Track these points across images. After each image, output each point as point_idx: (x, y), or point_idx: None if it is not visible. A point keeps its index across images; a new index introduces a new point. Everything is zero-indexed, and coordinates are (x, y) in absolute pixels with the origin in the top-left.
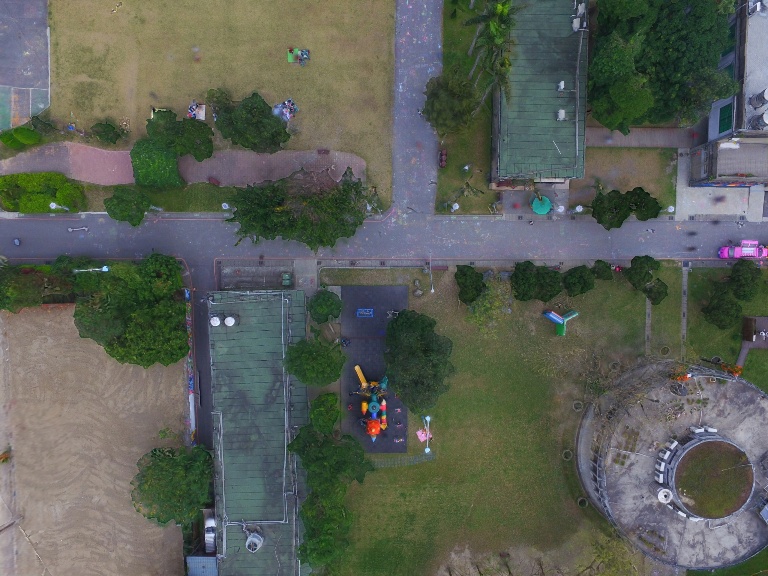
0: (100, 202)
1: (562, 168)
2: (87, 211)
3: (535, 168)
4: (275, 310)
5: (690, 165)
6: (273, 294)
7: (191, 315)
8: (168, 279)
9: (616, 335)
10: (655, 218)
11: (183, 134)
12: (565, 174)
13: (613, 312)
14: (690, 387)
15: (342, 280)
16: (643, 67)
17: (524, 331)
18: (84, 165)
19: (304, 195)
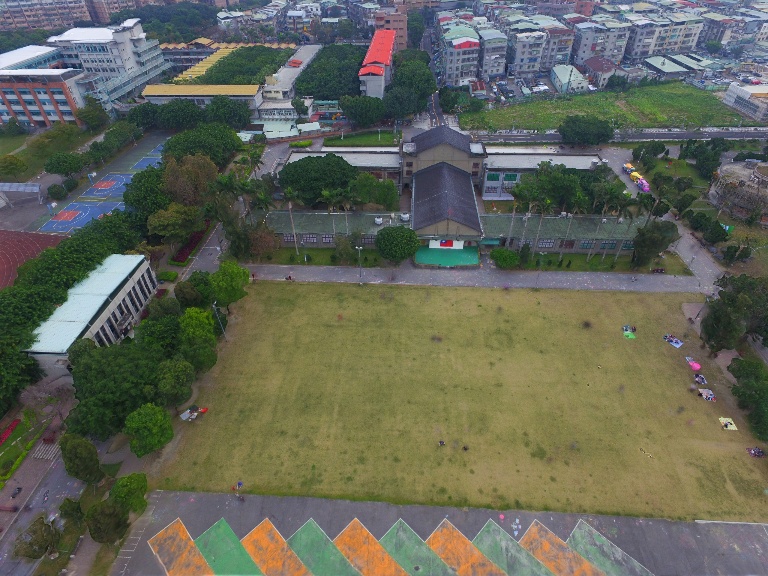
0: None
1: None
2: None
3: None
4: None
5: None
6: None
7: None
8: None
9: (713, 217)
10: None
11: None
12: None
13: None
14: (736, 183)
15: None
16: None
17: None
18: None
19: (761, 285)
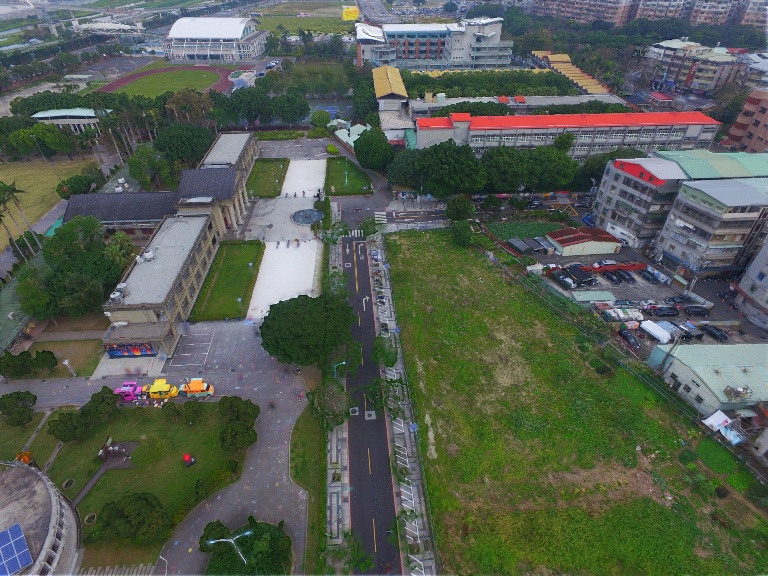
0: None
1: None
2: None
3: None
4: None
5: None
6: None
7: None
8: None
9: None
10: (74, 379)
11: None
12: None
13: None
14: None
15: None
16: None
17: None
18: None
19: None
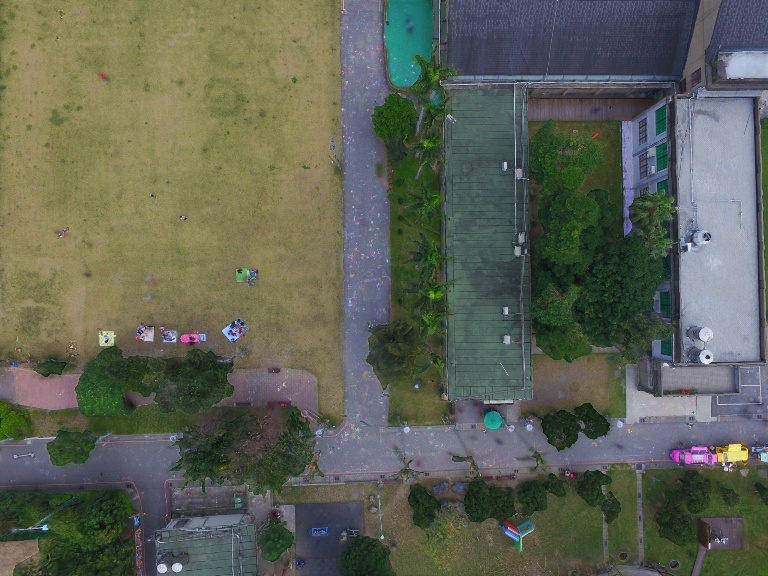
0: (47, 427)
1: (510, 390)
2: (33, 436)
3: (484, 391)
4: (225, 546)
5: (638, 369)
6: (223, 530)
7: (141, 540)
8: (113, 528)
9: (574, 542)
10: None
11: (127, 377)
12: (513, 396)
13: (570, 519)
14: None
15: (296, 498)
16: (581, 308)
17: (482, 542)
18: (30, 390)
19: (248, 452)
